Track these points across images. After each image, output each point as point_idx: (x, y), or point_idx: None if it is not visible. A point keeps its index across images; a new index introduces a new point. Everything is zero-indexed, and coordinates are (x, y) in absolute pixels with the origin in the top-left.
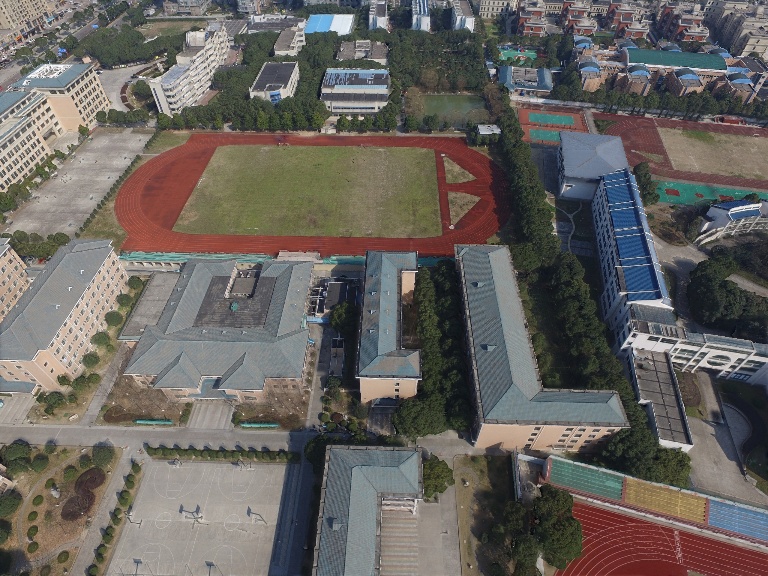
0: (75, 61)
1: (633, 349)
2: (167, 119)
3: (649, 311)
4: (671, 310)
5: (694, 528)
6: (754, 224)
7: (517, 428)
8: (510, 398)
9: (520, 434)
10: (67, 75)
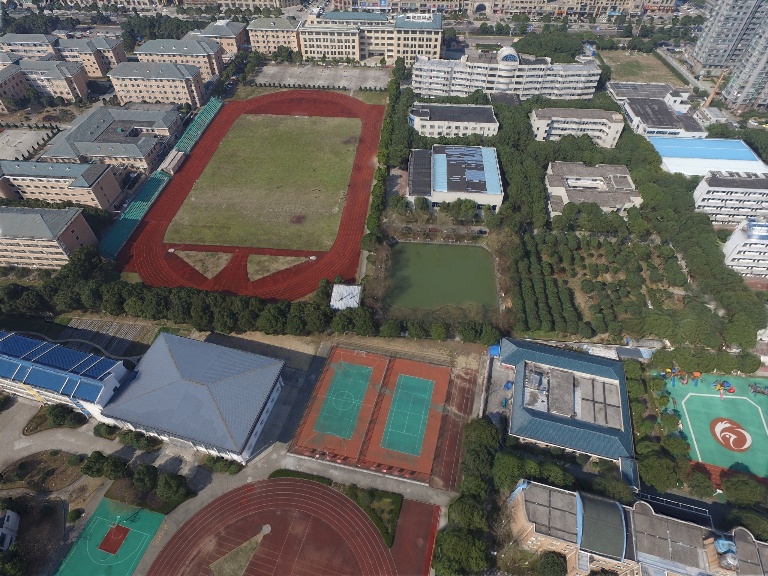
0: None
1: None
2: None
3: None
4: None
5: None
6: None
7: None
8: None
9: None
10: (414, 24)
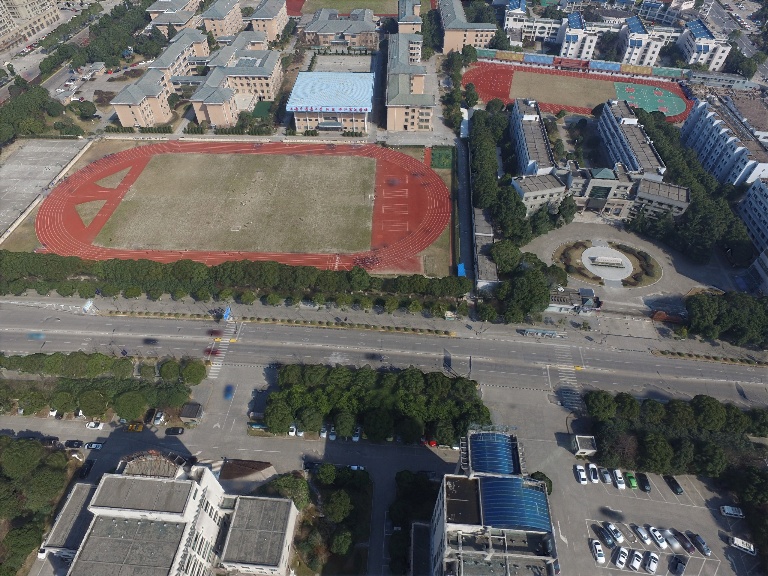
0: None
1: None
2: None
3: None
4: None
5: (520, 64)
6: (581, 7)
7: (458, 35)
8: (455, 22)
9: (459, 41)
10: None
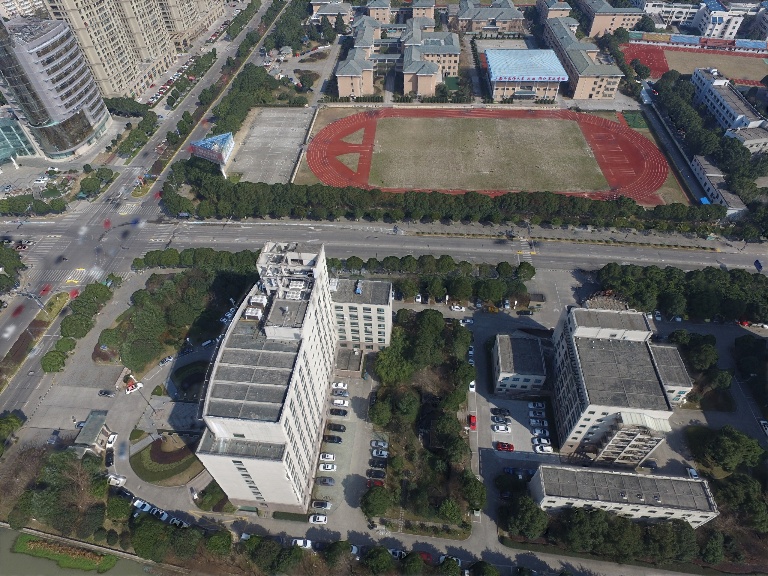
0: None
1: (647, 12)
2: None
3: (653, 0)
4: (661, 0)
5: (666, 45)
6: None
7: (606, 19)
8: (604, 7)
9: (607, 24)
10: None
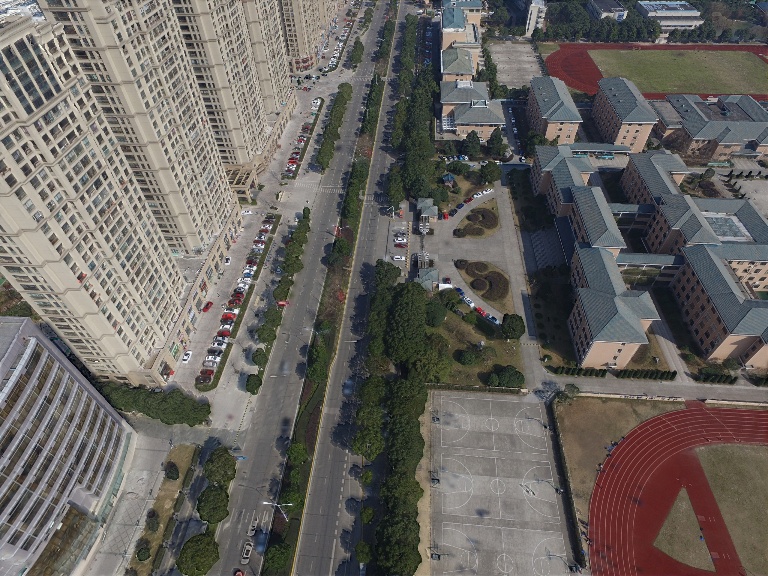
0: (408, 4)
1: None
2: (542, 33)
3: None
4: None
5: None
6: None
7: None
8: None
9: None
10: None
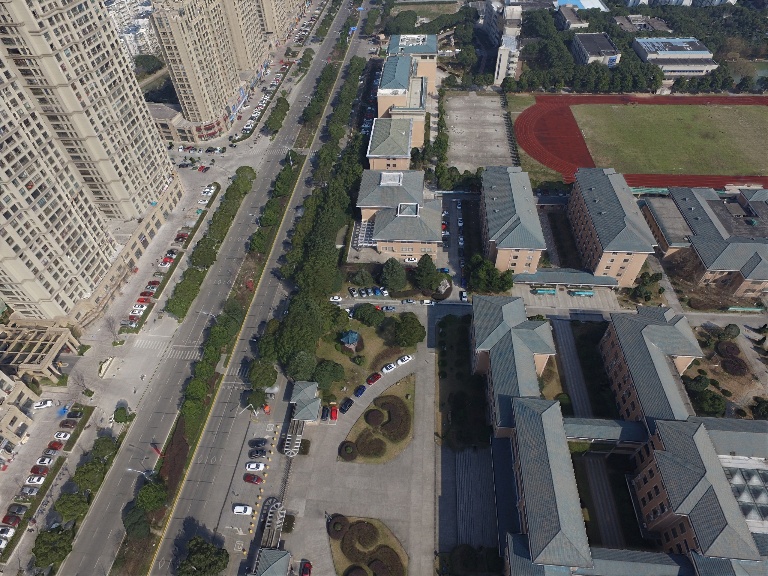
0: (361, 39)
1: None
2: (514, 82)
3: None
4: None
5: None
6: None
7: None
8: None
9: None
10: (431, 43)
